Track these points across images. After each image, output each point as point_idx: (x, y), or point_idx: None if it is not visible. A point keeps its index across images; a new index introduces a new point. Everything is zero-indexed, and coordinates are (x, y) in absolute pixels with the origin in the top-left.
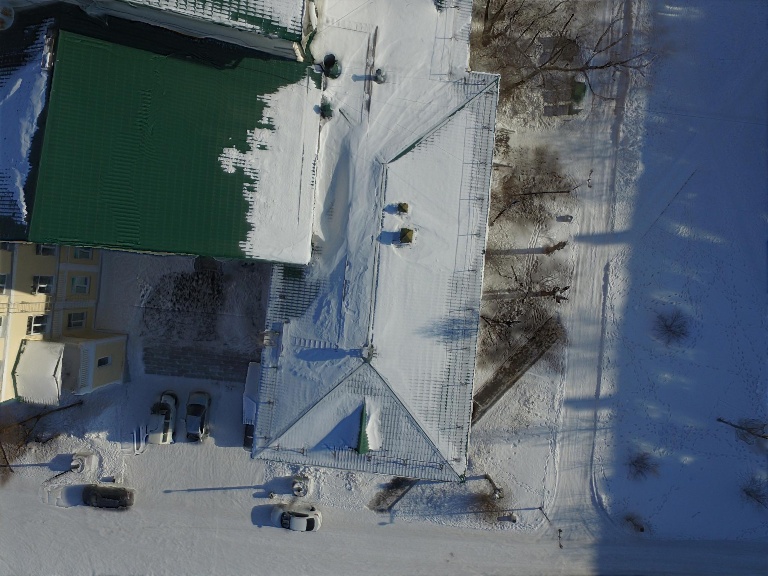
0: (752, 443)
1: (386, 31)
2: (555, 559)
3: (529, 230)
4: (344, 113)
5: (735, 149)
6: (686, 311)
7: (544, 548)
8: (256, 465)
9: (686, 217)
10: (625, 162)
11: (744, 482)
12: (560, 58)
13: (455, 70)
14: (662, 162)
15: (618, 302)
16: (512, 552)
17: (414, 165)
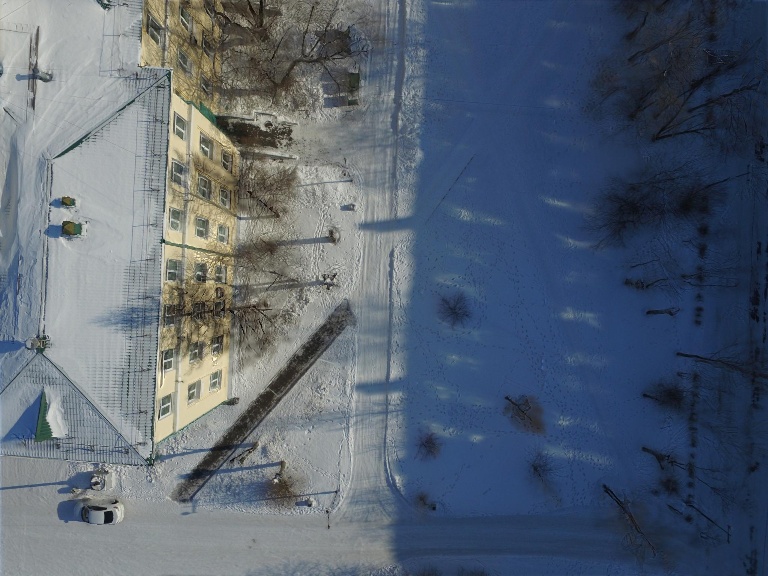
0: (523, 418)
1: (50, 31)
2: (354, 541)
3: (314, 220)
4: (9, 112)
5: (511, 132)
6: (469, 293)
7: (343, 530)
8: (59, 462)
9: (467, 201)
10: (405, 149)
11: (531, 457)
12: (338, 50)
13: (126, 66)
14: (441, 148)
15: (404, 287)
16: (312, 536)
17: (82, 160)
